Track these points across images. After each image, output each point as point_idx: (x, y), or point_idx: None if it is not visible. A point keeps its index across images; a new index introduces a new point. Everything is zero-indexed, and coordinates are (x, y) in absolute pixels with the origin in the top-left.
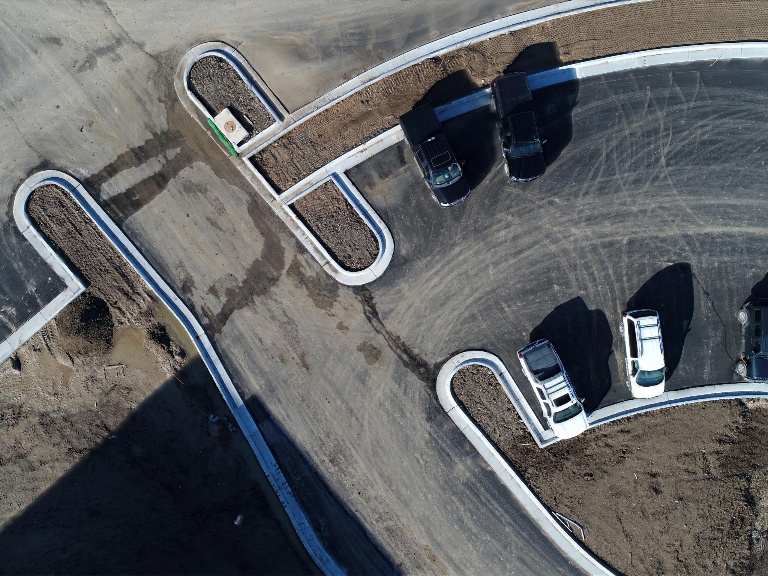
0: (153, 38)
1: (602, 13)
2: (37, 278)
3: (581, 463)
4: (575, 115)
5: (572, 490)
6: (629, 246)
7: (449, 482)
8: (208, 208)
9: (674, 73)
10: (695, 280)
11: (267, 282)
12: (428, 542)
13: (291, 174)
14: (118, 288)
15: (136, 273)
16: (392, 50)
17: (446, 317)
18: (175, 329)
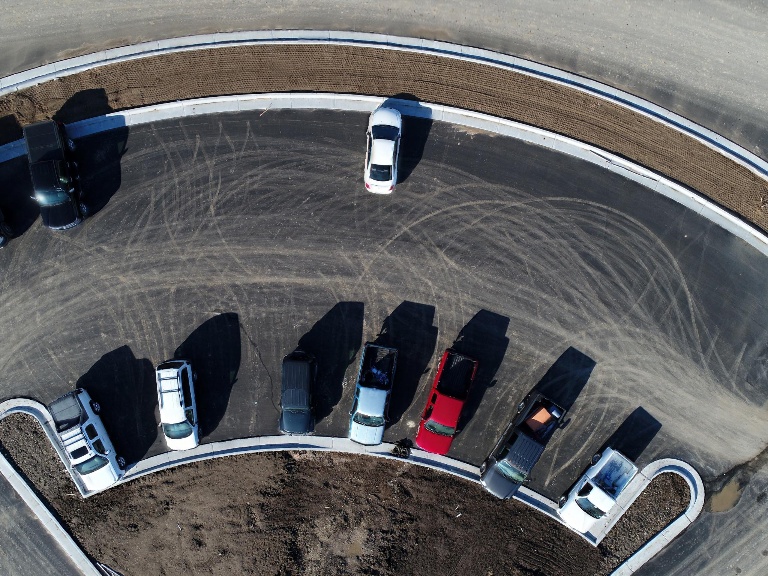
0: None
1: (150, 61)
2: None
3: (125, 514)
4: (124, 162)
5: (116, 541)
6: (176, 295)
7: None
8: None
9: (224, 122)
10: (242, 330)
11: None
12: None
13: None
14: None
15: None
16: None
17: None
18: None
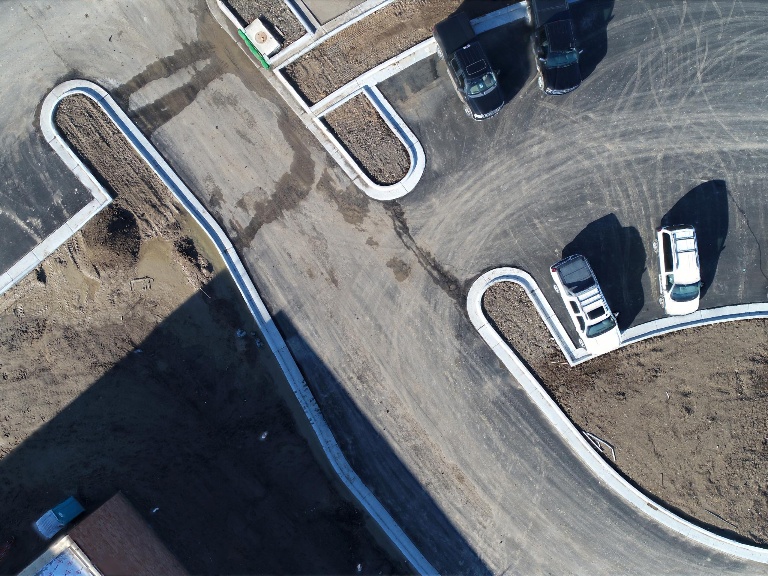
0: None
1: None
2: (63, 189)
3: (613, 382)
4: (610, 29)
5: (603, 409)
6: (663, 163)
7: (479, 401)
8: (237, 120)
9: None
10: (730, 198)
11: (296, 196)
12: (457, 461)
13: (322, 86)
14: (145, 200)
15: (164, 185)
16: None
17: (477, 233)
18: (203, 243)
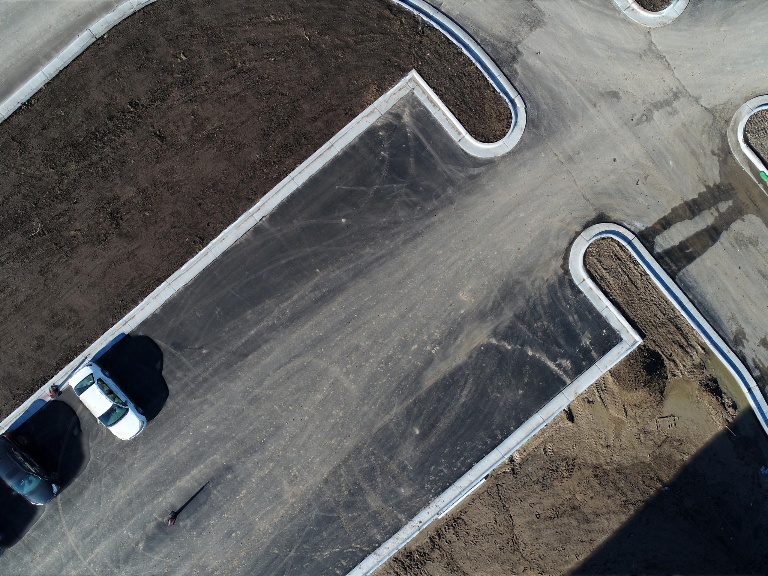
0: (709, 91)
1: None
2: (592, 330)
3: None
4: None
5: None
6: None
7: None
8: (759, 260)
9: None
10: None
11: None
12: None
13: None
14: (673, 340)
15: (690, 325)
16: None
17: None
18: (726, 381)
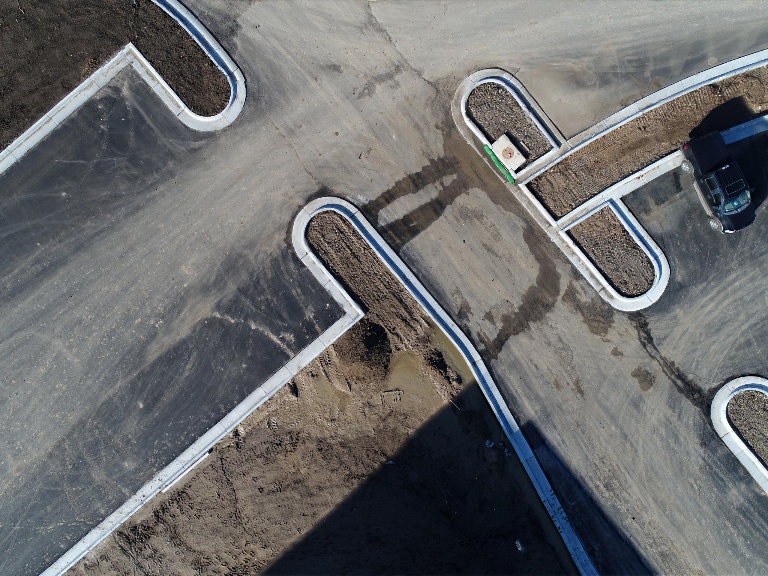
0: (431, 65)
1: None
2: (315, 304)
3: None
4: None
5: None
6: None
7: (723, 507)
8: (484, 234)
9: None
10: None
11: (542, 308)
12: (702, 567)
13: (567, 200)
14: (396, 314)
15: (413, 299)
16: (670, 77)
17: (721, 343)
18: (451, 355)
